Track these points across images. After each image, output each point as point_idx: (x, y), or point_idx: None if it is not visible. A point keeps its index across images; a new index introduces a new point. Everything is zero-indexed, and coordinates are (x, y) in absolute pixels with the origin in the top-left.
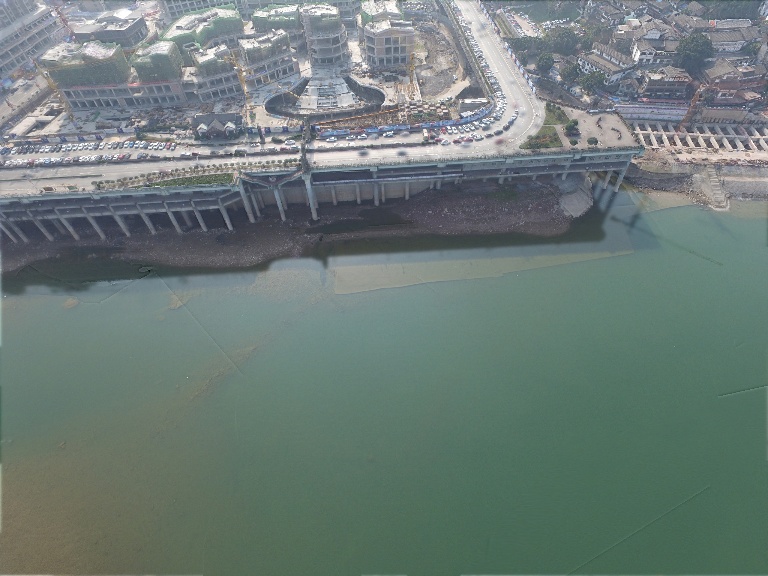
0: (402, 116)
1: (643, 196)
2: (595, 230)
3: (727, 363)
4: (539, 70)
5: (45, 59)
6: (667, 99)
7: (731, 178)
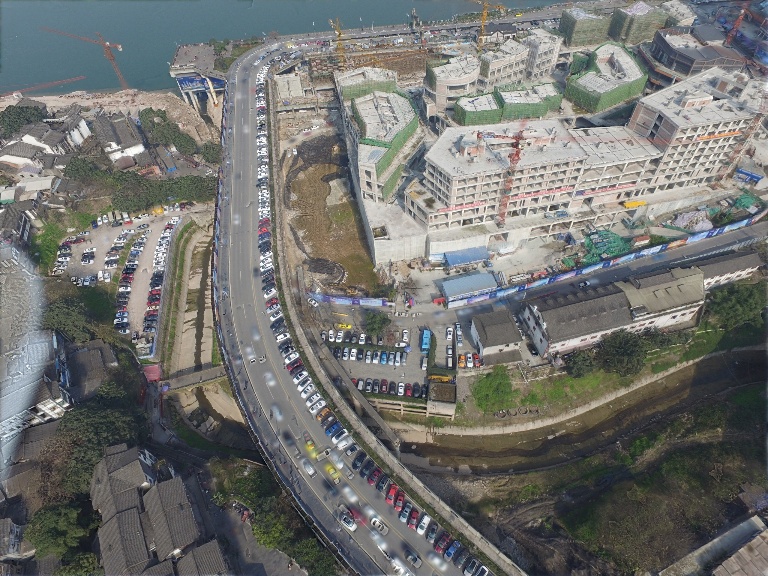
0: None
1: (177, 94)
2: None
3: None
4: None
5: (673, 0)
6: None
7: None
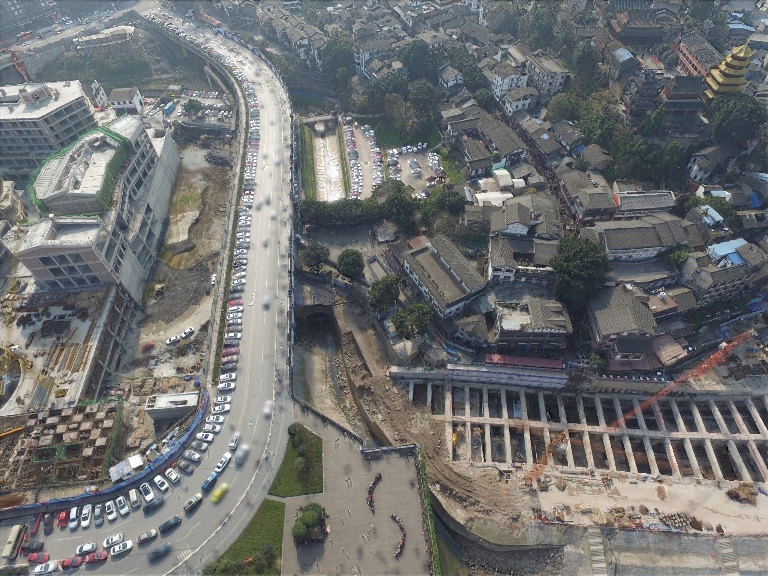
0: (17, 453)
1: None
2: None
3: None
4: (343, 275)
5: None
6: (534, 356)
7: (630, 557)
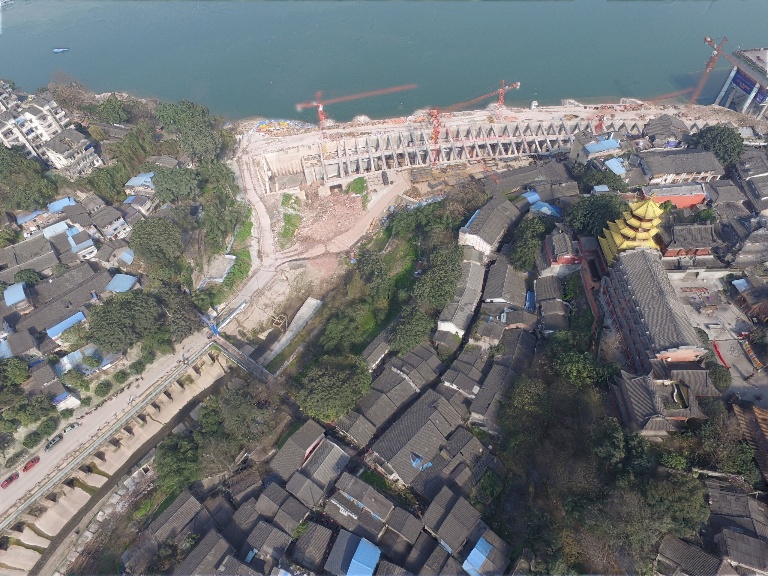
0: None
1: None
2: (720, 82)
3: (654, 5)
4: None
5: None
6: None
7: None
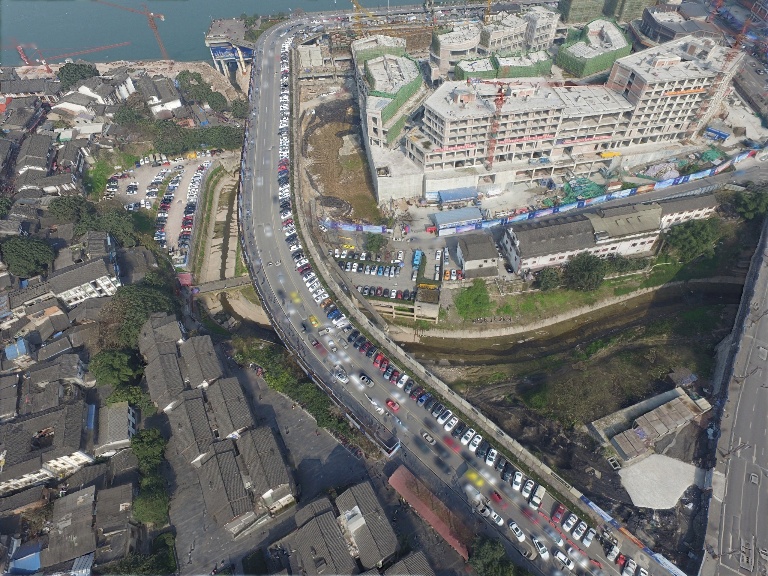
0: None
1: None
2: None
3: None
4: None
5: None
6: None
7: None
